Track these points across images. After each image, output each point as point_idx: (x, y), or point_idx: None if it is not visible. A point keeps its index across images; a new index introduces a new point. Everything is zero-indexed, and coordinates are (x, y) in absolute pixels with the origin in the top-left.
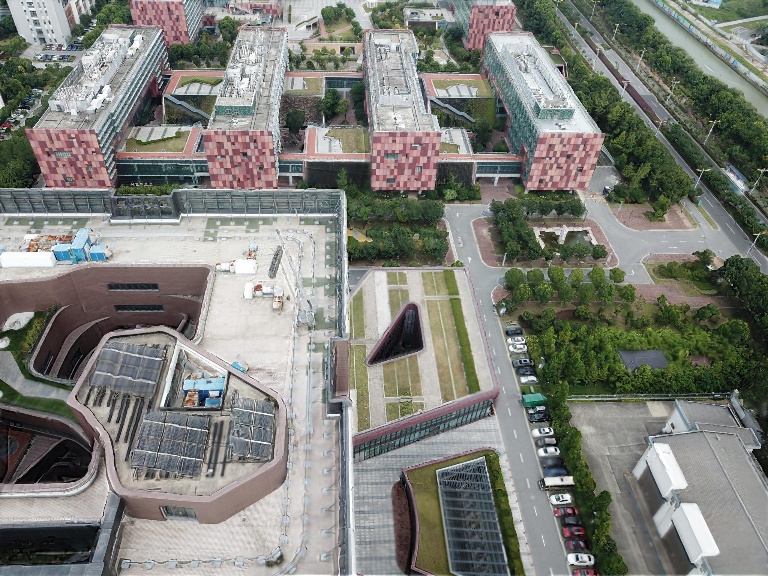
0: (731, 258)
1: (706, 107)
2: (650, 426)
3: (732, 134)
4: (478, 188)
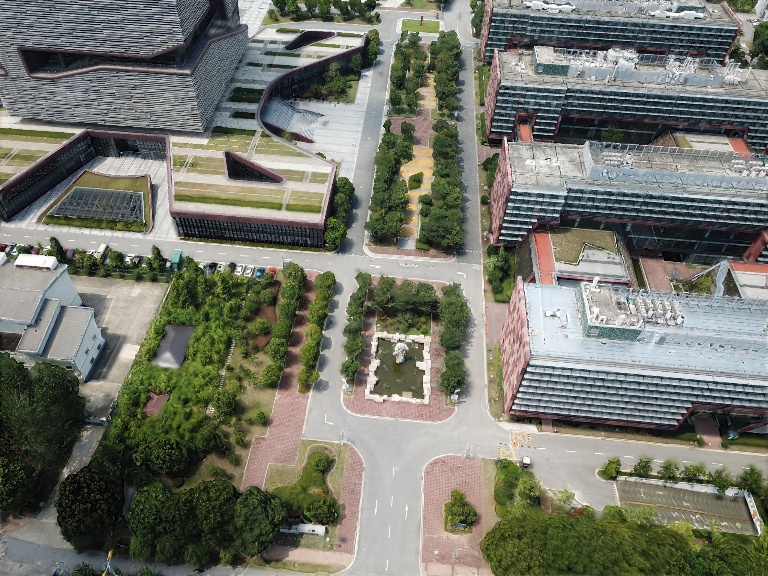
0: (279, 504)
1: None
2: (116, 337)
3: None
4: (511, 295)
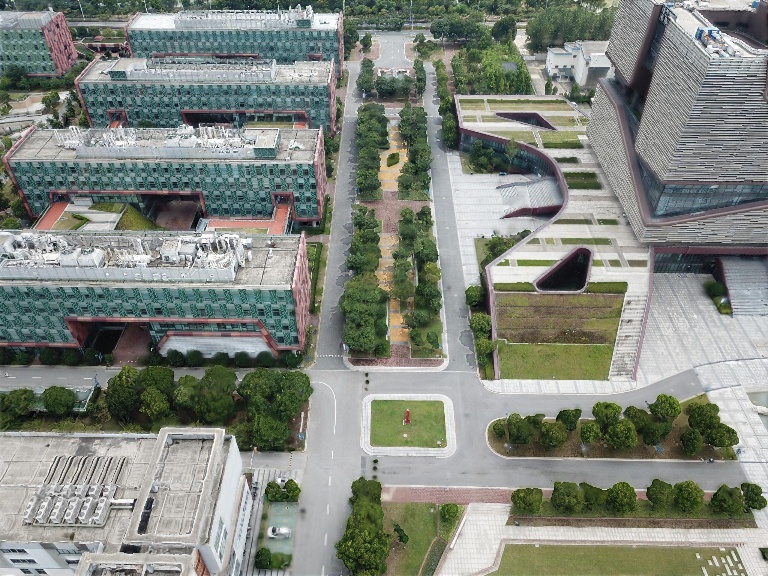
0: (434, 26)
1: (238, 6)
2: None
3: (284, 5)
4: None
